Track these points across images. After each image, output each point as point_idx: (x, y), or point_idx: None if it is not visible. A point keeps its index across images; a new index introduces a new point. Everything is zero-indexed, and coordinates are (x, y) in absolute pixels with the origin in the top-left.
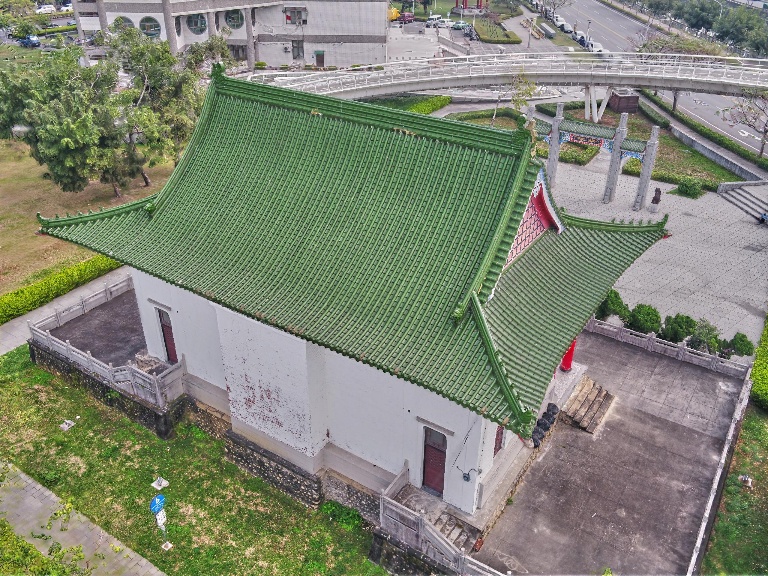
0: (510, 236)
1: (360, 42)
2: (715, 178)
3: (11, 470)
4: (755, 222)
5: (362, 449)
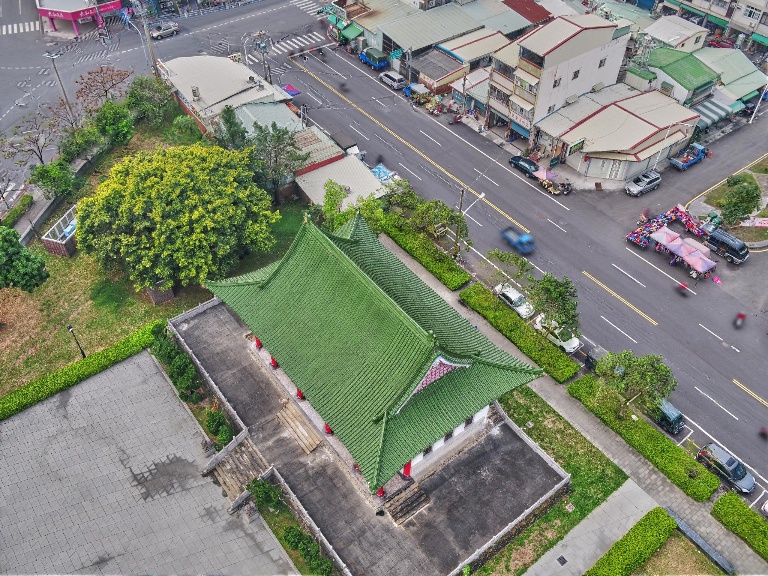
0: None
1: None
2: None
3: (551, 403)
4: None
5: None
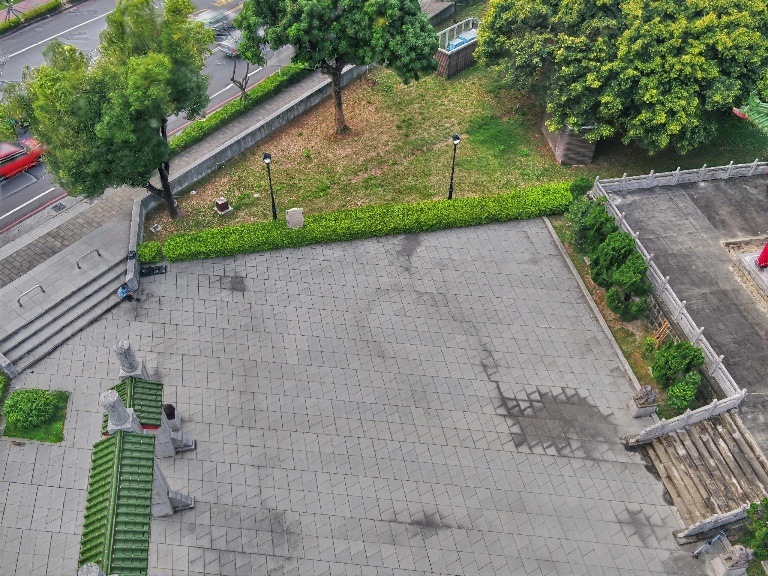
0: None
1: None
2: None
3: None
4: (131, 304)
5: None
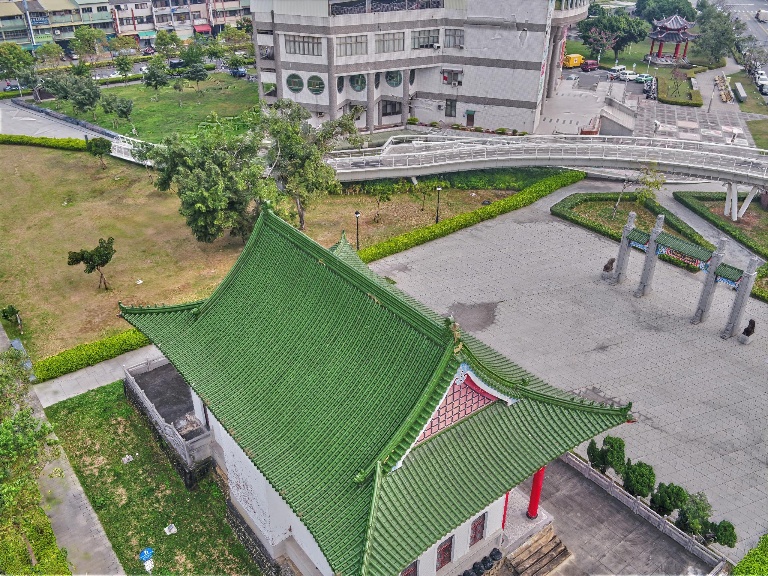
0: (424, 418)
1: (510, 106)
2: None
3: (77, 488)
4: None
5: (309, 551)
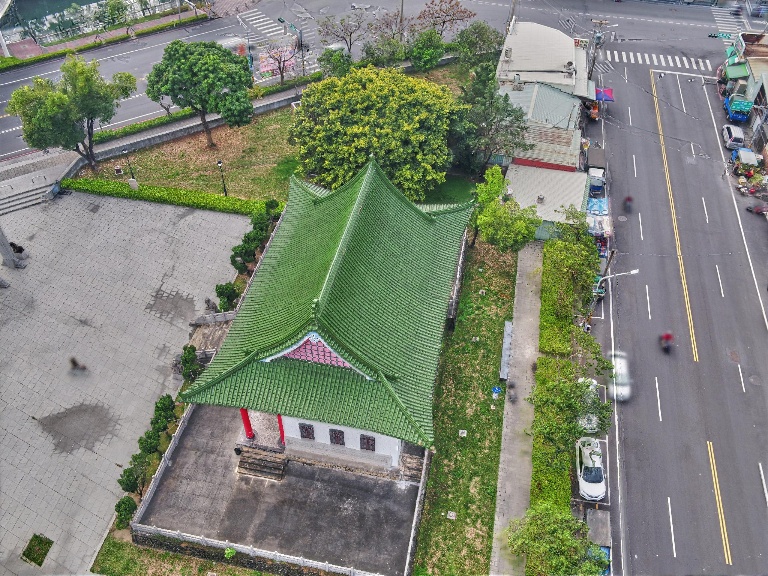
0: None
1: None
2: None
3: (498, 519)
4: (45, 205)
5: None
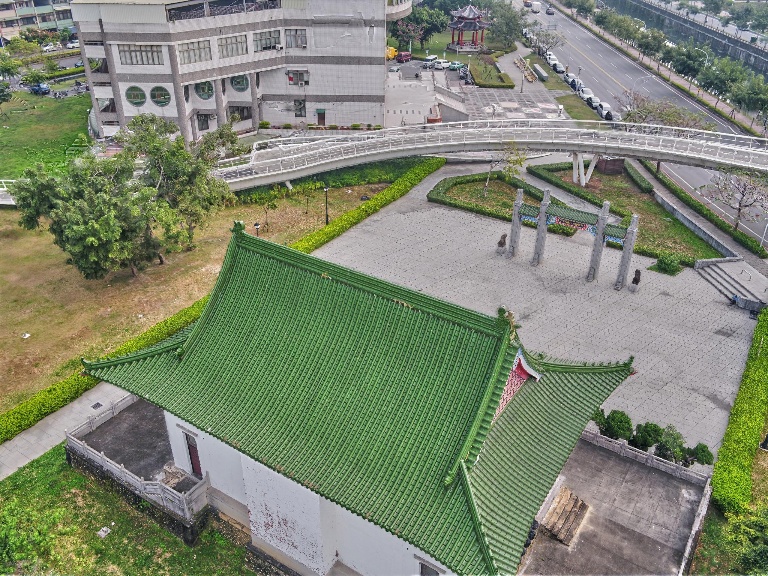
0: (493, 408)
1: (359, 101)
2: (693, 251)
3: None
4: (727, 303)
5: (367, 570)
